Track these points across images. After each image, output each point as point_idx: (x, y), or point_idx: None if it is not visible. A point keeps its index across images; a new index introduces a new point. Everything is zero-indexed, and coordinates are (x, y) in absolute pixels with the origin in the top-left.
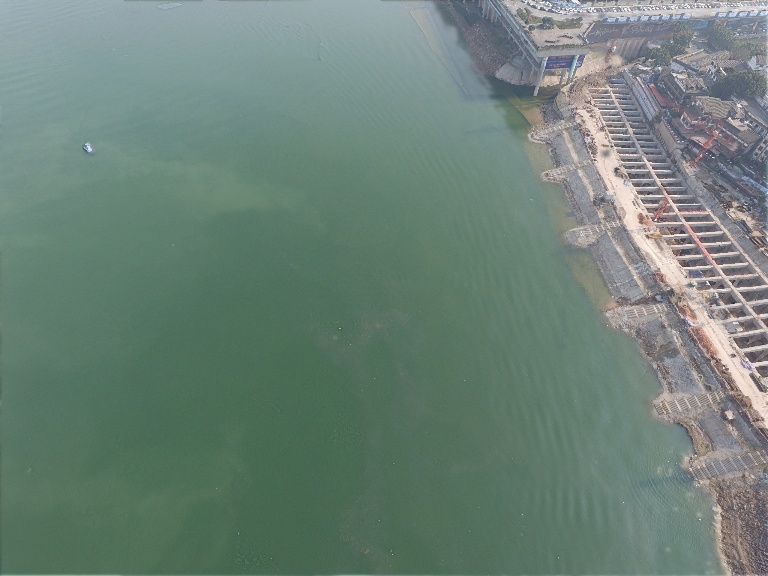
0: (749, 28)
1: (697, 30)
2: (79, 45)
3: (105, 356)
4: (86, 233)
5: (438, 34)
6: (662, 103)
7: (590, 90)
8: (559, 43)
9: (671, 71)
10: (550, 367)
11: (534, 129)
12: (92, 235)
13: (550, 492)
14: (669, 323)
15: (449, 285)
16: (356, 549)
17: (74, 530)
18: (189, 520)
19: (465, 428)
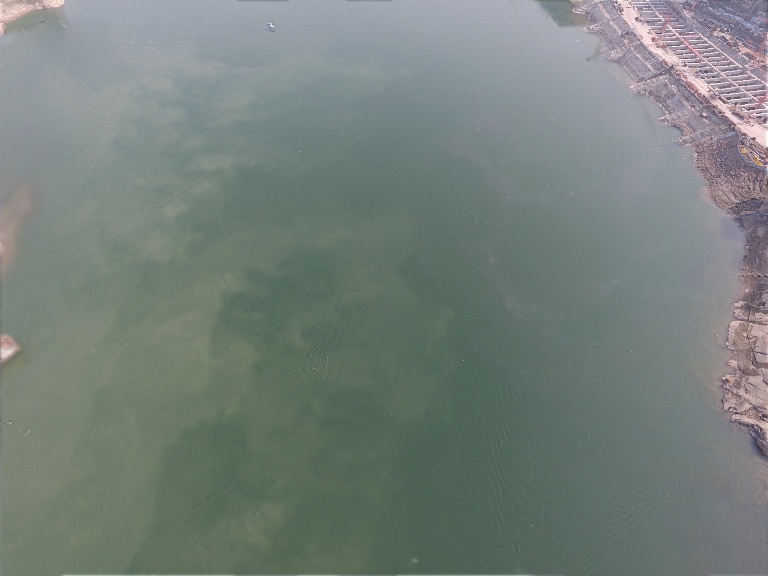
0: None
1: None
2: None
3: (328, 105)
4: (287, 65)
5: None
6: None
7: None
8: None
9: None
10: (595, 109)
11: (577, 6)
12: (291, 66)
13: None
14: (670, 83)
15: (527, 78)
16: (491, 169)
17: (337, 165)
18: (399, 158)
19: (545, 130)
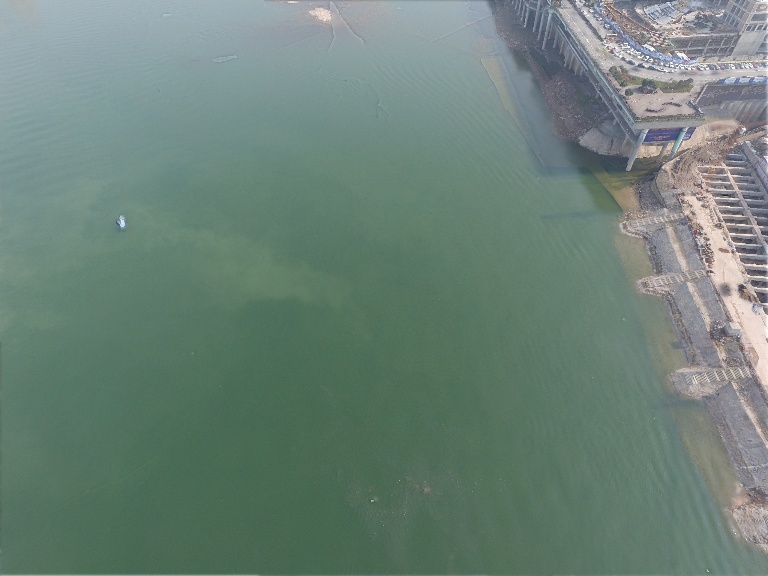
0: None
1: None
2: (132, 99)
3: (91, 516)
4: (103, 330)
5: (512, 88)
6: None
7: (700, 168)
8: (664, 113)
9: None
10: None
11: (627, 217)
12: (109, 333)
13: None
14: None
15: (515, 443)
16: None
17: None
18: None
19: None
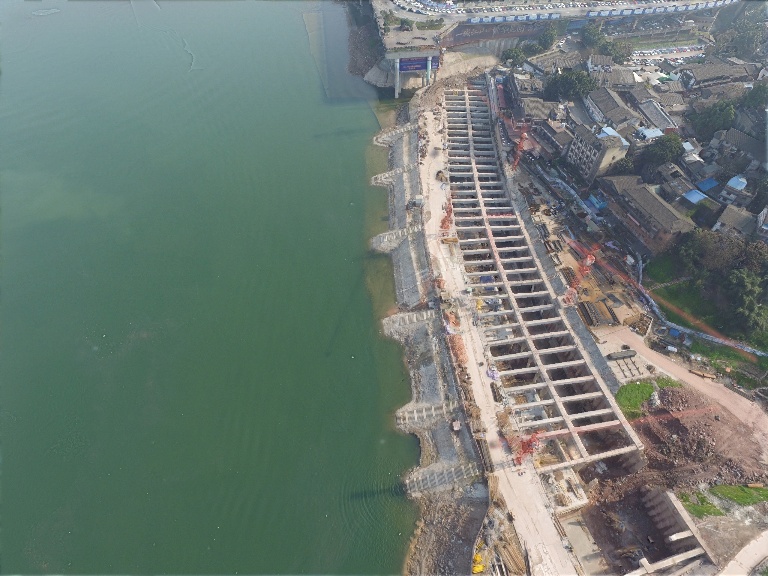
0: (630, 27)
1: (577, 29)
2: None
3: None
4: None
5: (322, 37)
6: (501, 104)
7: (447, 92)
8: (410, 45)
9: (514, 72)
10: (306, 375)
11: (381, 132)
12: None
13: (253, 505)
14: (433, 330)
15: (235, 291)
16: (35, 562)
17: None
18: None
19: (193, 438)
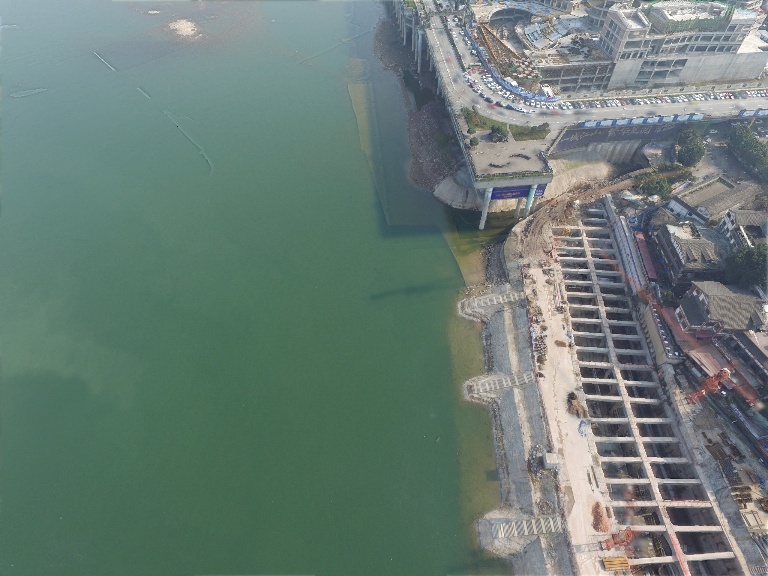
0: None
1: (714, 125)
2: None
3: None
4: None
5: (374, 121)
6: (651, 273)
7: (554, 229)
8: (509, 168)
9: (666, 223)
10: None
11: (468, 293)
12: None
13: None
14: None
15: None
16: None
17: None
18: None
19: None
